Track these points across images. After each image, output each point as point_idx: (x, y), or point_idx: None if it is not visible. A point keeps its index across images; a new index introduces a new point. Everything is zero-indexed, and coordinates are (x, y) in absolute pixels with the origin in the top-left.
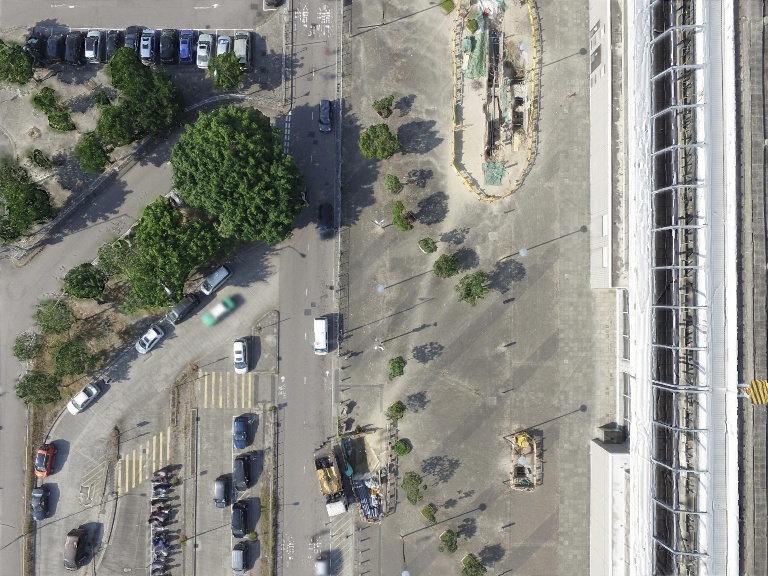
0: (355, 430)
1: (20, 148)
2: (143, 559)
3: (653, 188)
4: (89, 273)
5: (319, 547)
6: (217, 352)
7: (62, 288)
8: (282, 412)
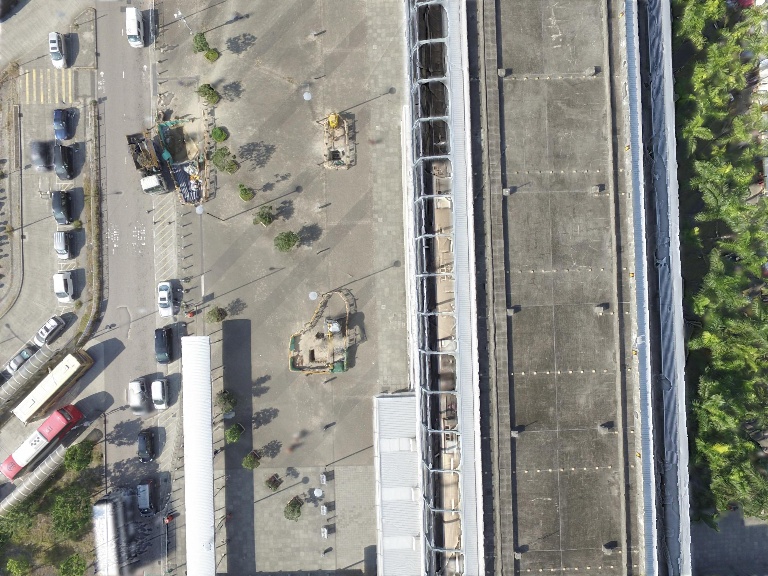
0: None
1: None
2: None
3: None
4: None
5: (143, 234)
6: (37, 50)
7: None
8: (102, 106)
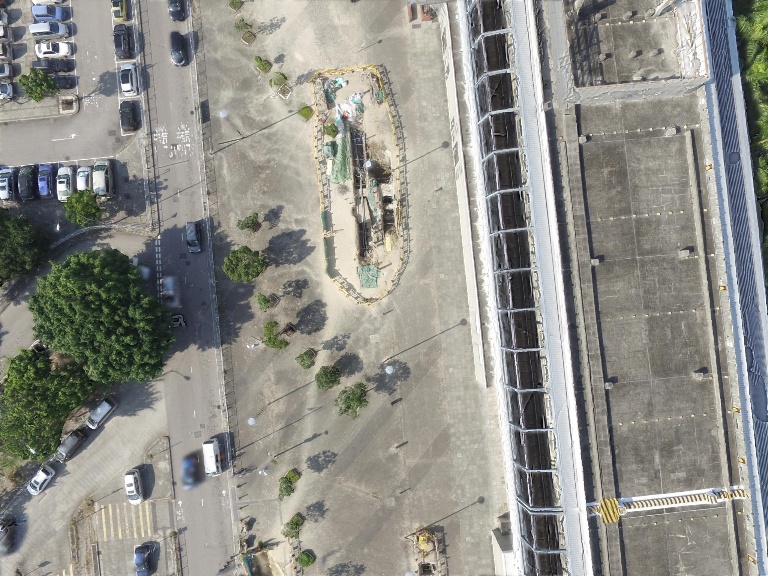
0: (257, 547)
1: None
2: None
3: (499, 305)
4: None
5: None
6: (111, 484)
7: None
8: (183, 536)
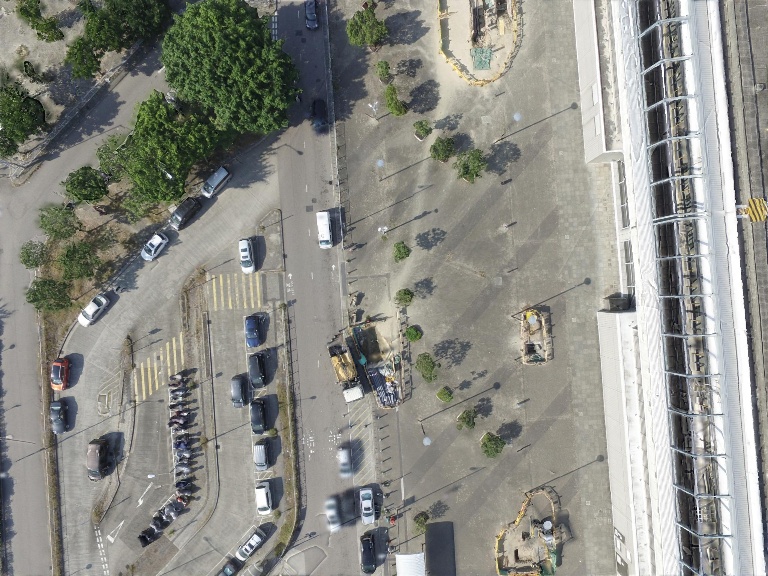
0: (365, 320)
1: (9, 67)
2: (166, 464)
3: (639, 32)
4: (90, 174)
5: (339, 438)
6: (223, 255)
7: (63, 202)
8: (292, 309)
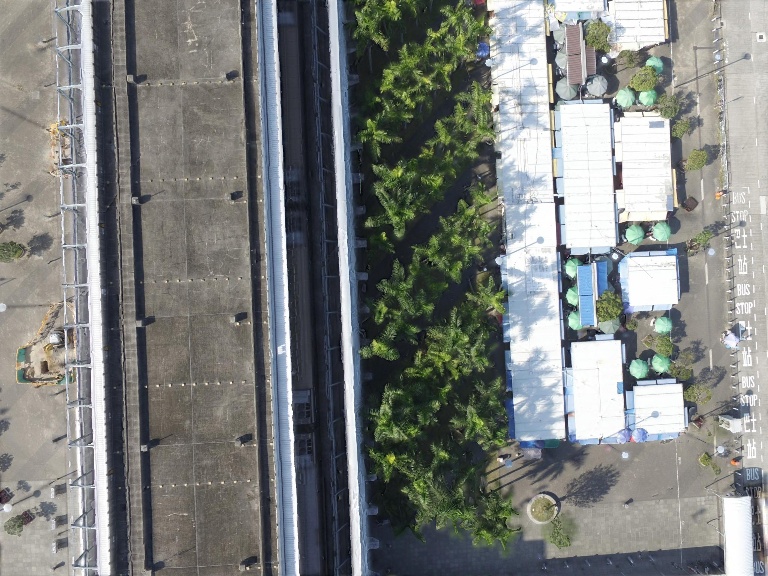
0: None
1: None
2: None
3: None
4: None
5: None
6: None
7: None
8: None
